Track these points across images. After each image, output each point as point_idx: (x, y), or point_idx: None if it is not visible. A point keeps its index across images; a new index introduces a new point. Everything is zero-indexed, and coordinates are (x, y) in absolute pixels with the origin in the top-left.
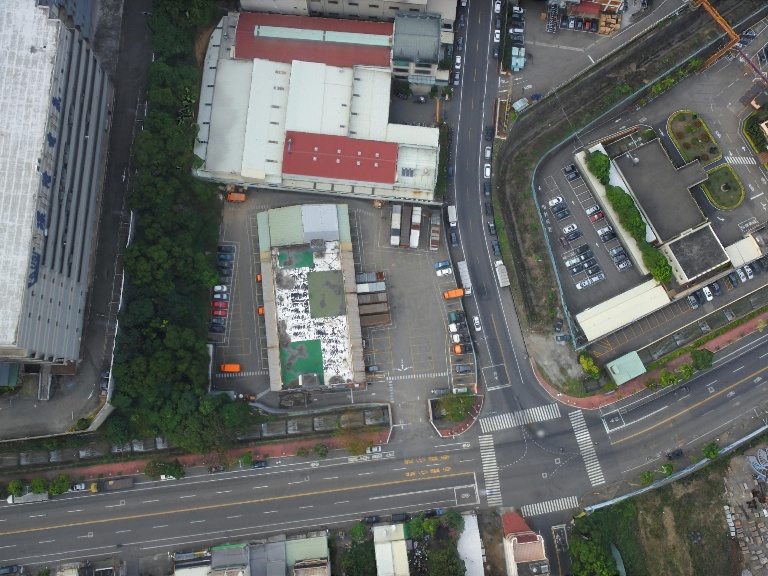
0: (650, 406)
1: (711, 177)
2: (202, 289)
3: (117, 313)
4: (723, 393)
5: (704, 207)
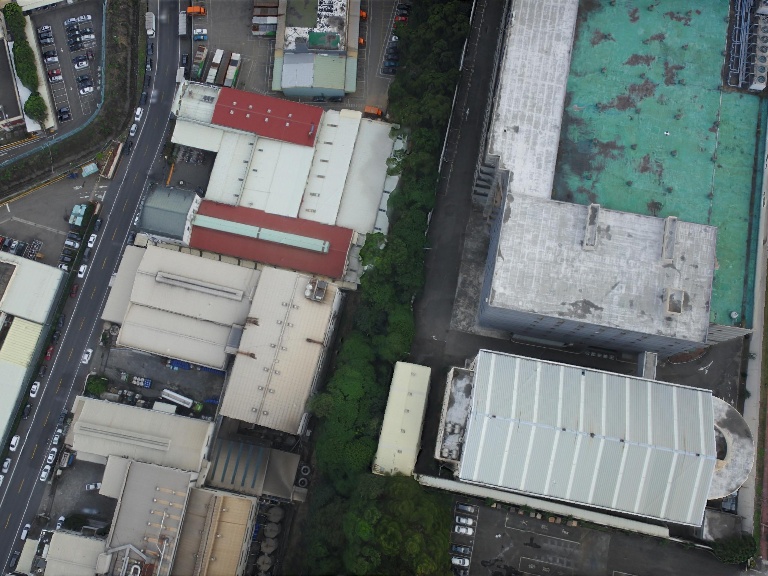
0: None
1: None
2: None
3: None
4: None
5: None
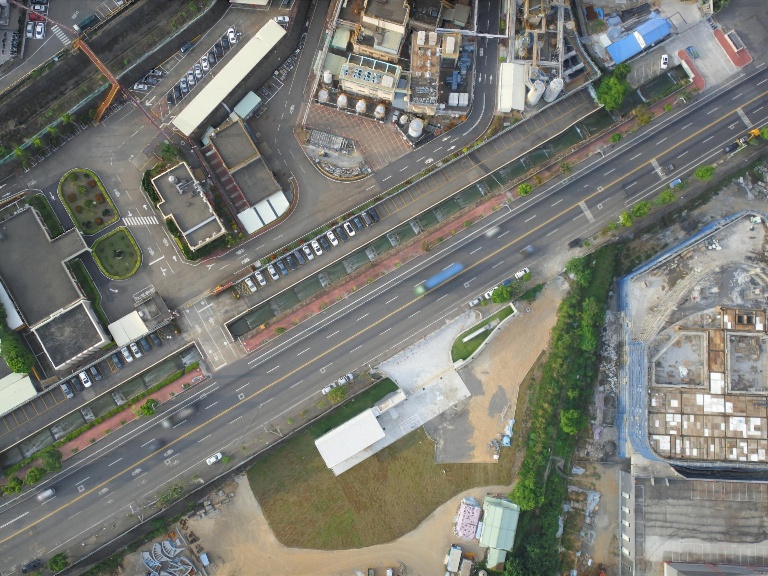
0: (8, 514)
1: (105, 243)
2: None
3: None
4: (95, 491)
5: (96, 278)
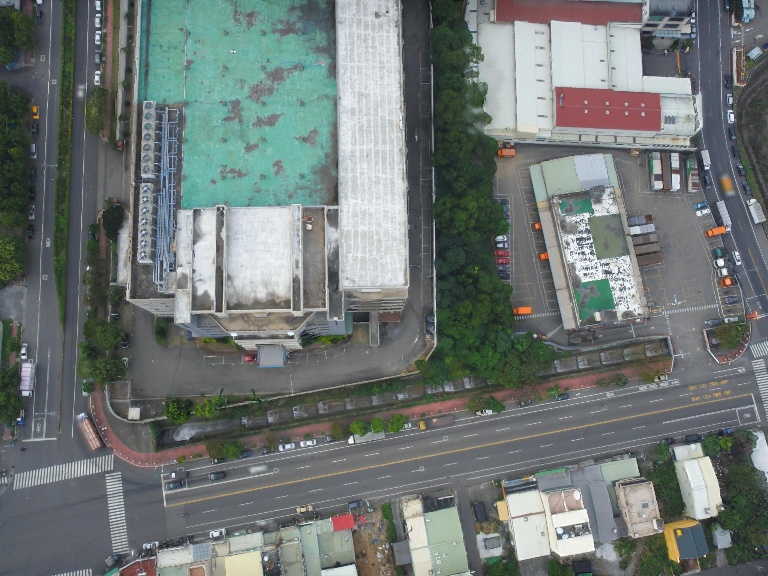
0: None
1: None
2: (486, 239)
3: (433, 262)
4: None
5: None
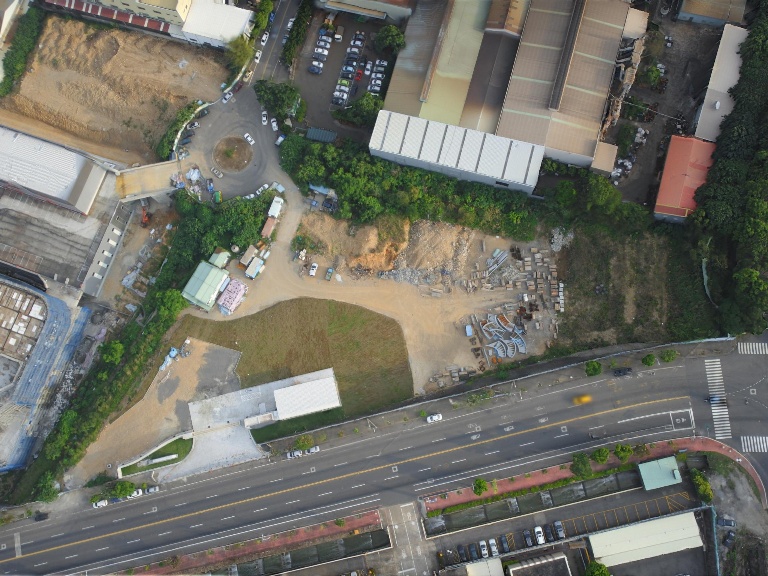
0: (637, 427)
1: None
2: None
3: None
4: (552, 423)
5: None
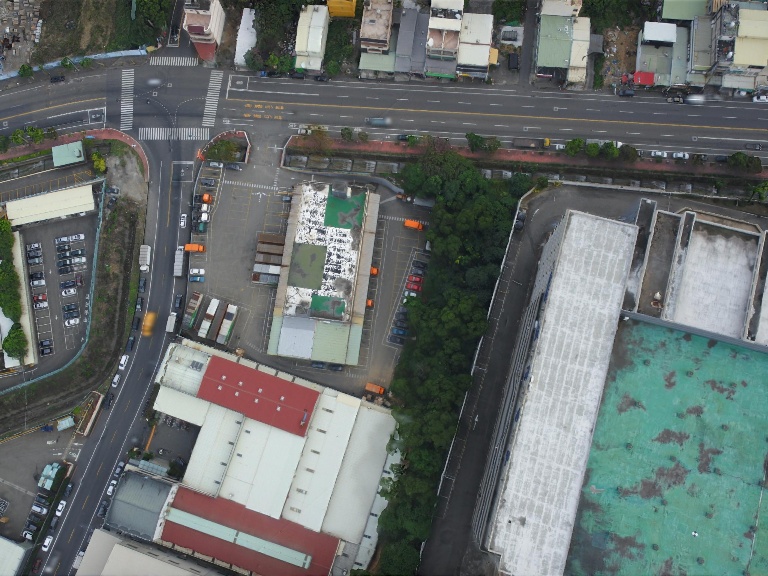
0: (62, 121)
1: None
2: None
3: None
4: None
5: None
